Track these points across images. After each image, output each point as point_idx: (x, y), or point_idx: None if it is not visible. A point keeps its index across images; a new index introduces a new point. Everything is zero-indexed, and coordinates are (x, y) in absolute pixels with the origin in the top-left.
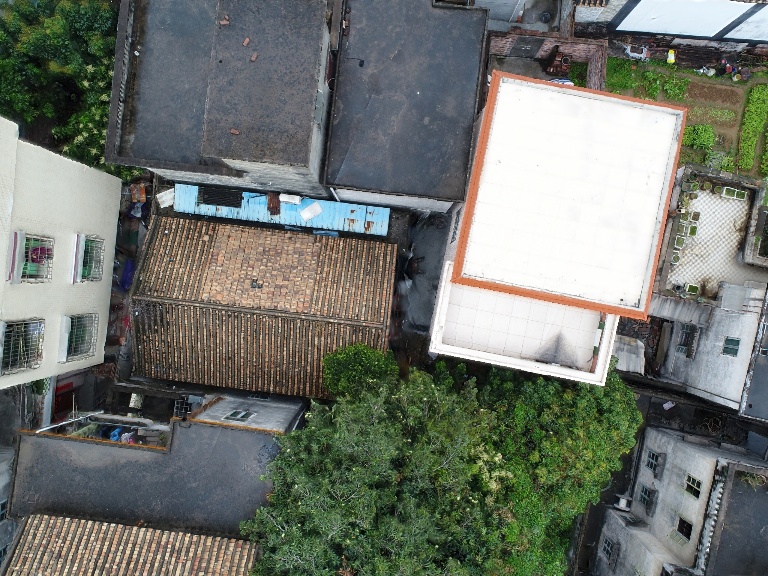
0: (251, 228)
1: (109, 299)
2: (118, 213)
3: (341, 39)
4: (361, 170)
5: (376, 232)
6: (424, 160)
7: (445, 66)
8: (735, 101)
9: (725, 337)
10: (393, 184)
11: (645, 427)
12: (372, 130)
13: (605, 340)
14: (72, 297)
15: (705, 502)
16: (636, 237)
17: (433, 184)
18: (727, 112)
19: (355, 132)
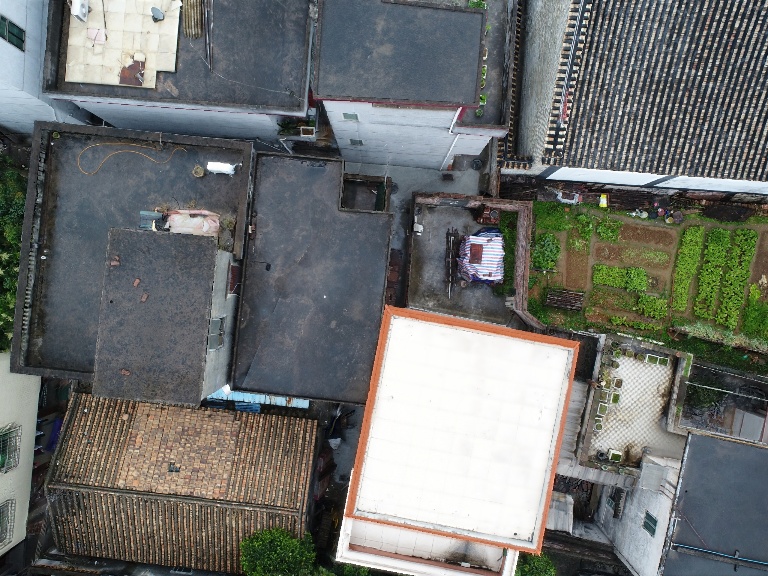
0: (171, 405)
1: (30, 474)
2: (39, 388)
3: (247, 244)
4: (268, 374)
5: (298, 405)
6: (331, 364)
7: (351, 270)
8: (668, 243)
9: (646, 510)
10: (300, 388)
11: (578, 574)
12: (279, 334)
13: None
14: None
15: None
16: (529, 472)
17: (340, 388)
18: (660, 254)
19: (262, 336)
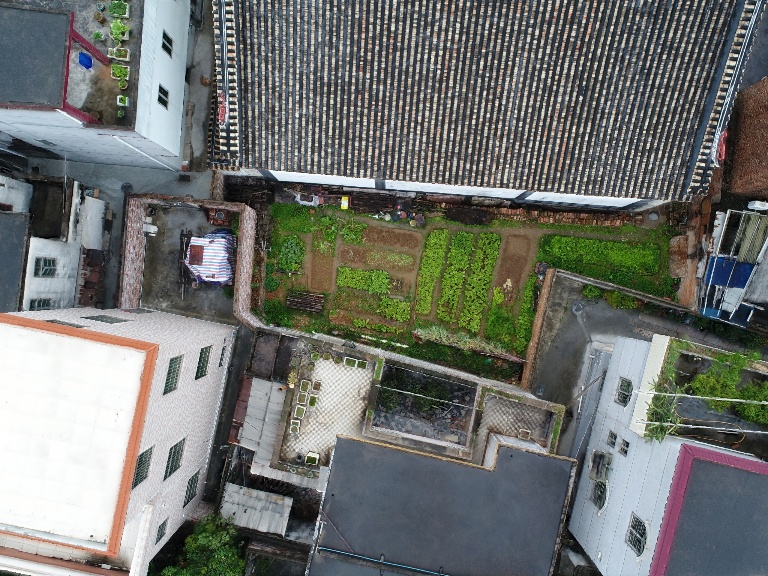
0: None
1: None
2: None
3: None
4: None
5: None
6: None
7: None
8: (413, 245)
9: None
10: None
11: None
12: None
13: (137, 549)
14: None
15: None
16: (105, 474)
17: None
18: (405, 256)
19: None
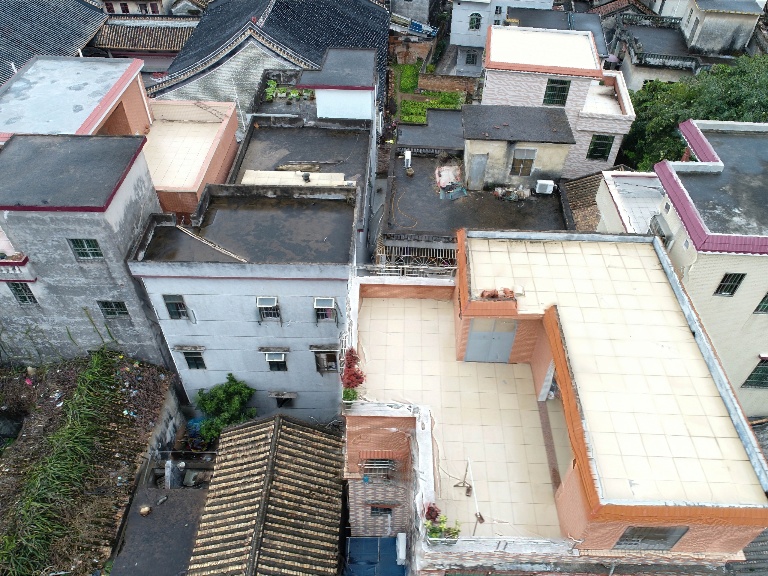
0: None
1: None
2: None
3: None
4: None
5: None
6: None
7: None
8: None
9: None
10: None
11: None
12: None
13: None
14: None
15: (655, 74)
16: None
17: None
18: None
19: None
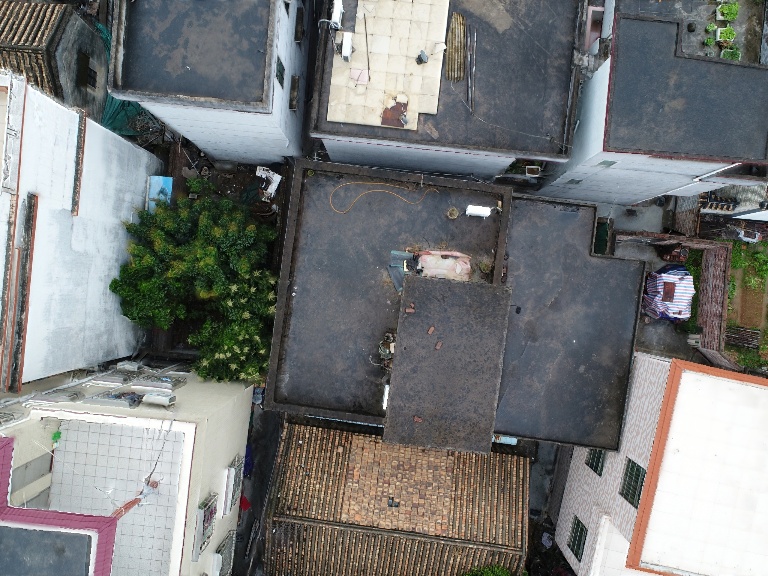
0: None
1: (239, 503)
2: (249, 417)
3: None
4: (515, 416)
5: (506, 441)
6: (579, 408)
7: (601, 315)
8: None
9: None
10: (547, 431)
11: None
12: (527, 377)
13: None
14: (220, 529)
15: None
16: None
17: (587, 432)
18: None
19: None
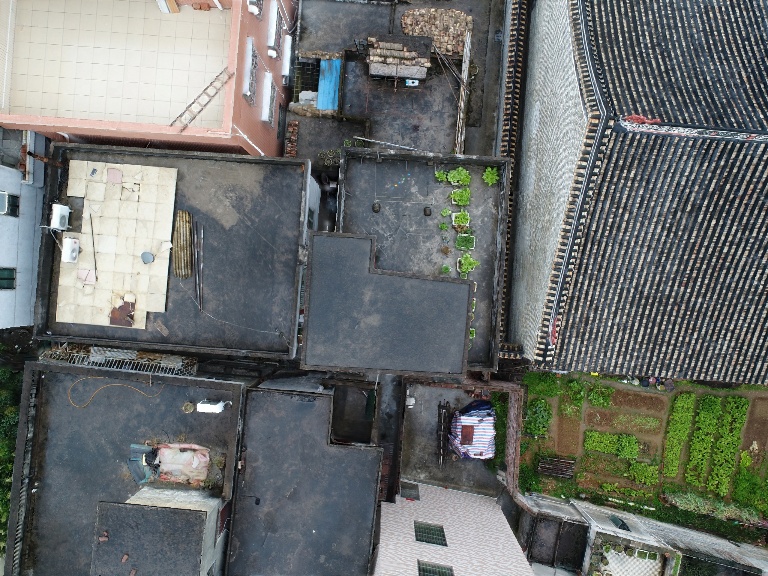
0: None
1: None
2: None
3: (237, 479)
4: None
5: None
6: None
7: (340, 504)
8: (660, 409)
9: None
10: None
11: None
12: (268, 568)
13: None
14: None
15: None
16: None
17: None
18: (652, 420)
19: (251, 570)
